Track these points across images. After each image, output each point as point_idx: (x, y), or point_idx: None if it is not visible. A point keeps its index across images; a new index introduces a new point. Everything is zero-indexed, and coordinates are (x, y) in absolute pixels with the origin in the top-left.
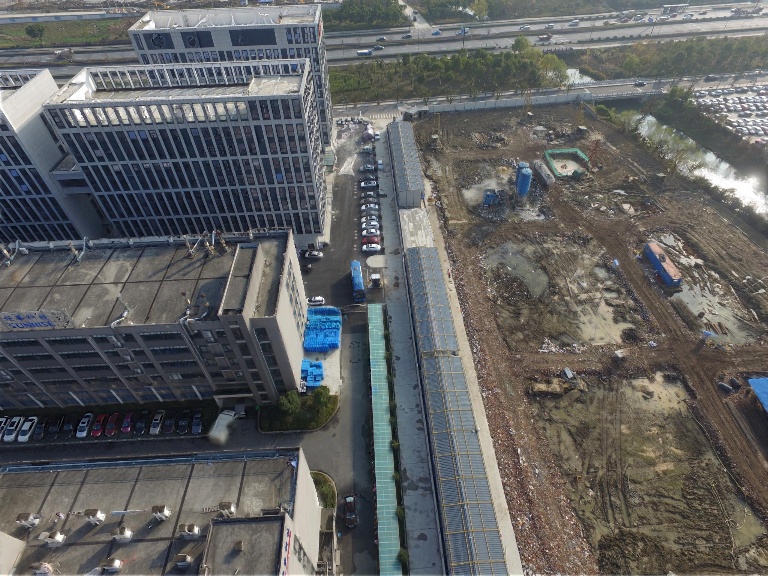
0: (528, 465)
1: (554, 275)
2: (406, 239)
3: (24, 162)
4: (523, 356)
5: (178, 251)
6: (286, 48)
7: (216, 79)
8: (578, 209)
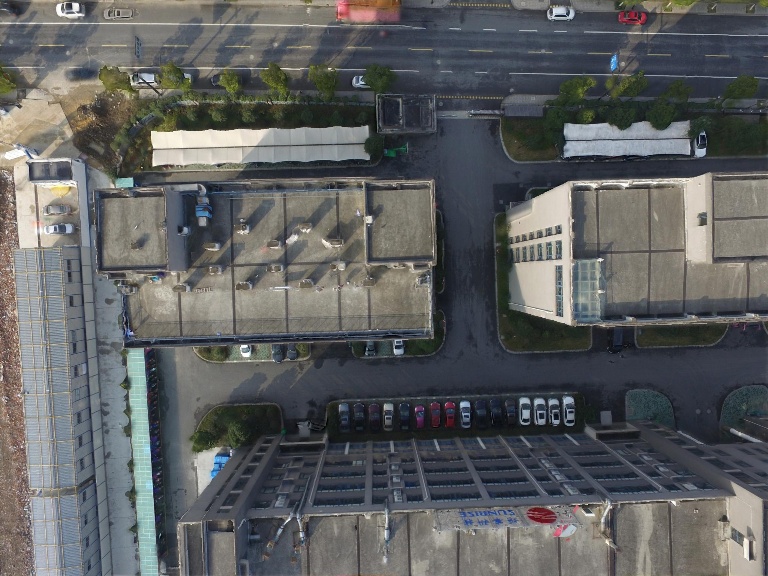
0: None
1: None
2: None
3: None
4: None
5: None
6: None
7: None
8: None
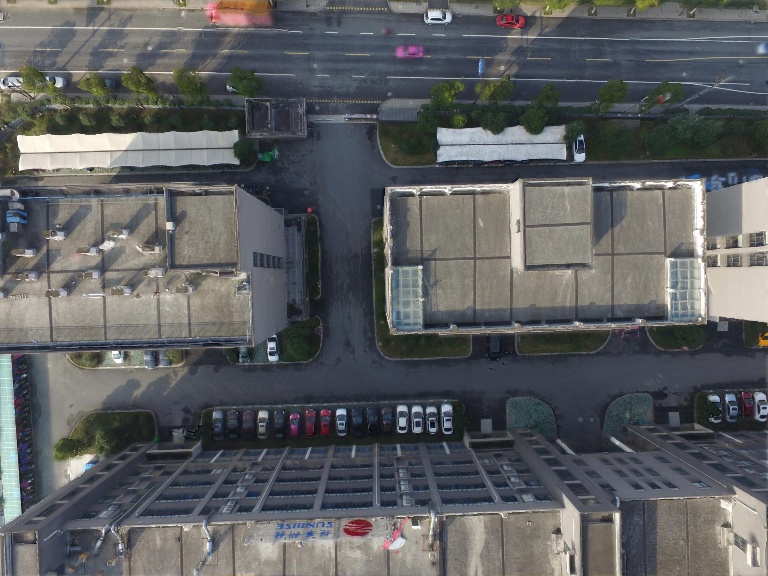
0: None
1: None
2: None
3: None
4: None
5: None
6: None
7: None
8: None
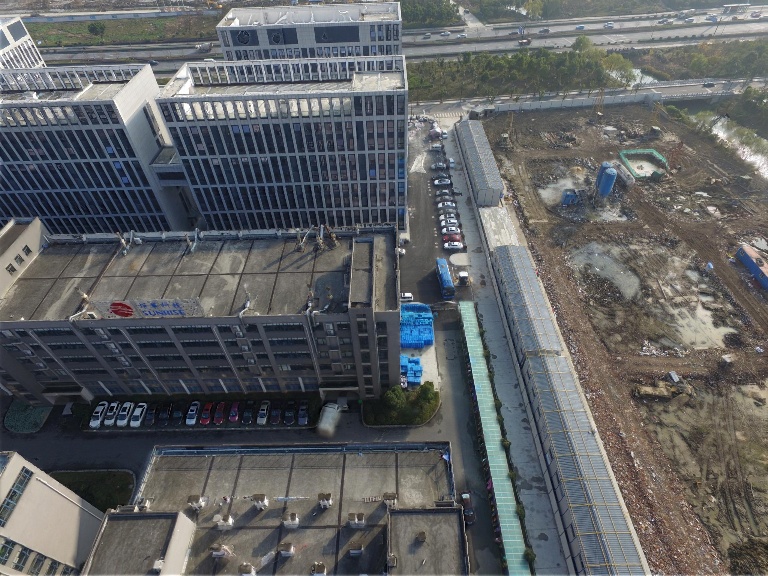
0: (644, 469)
1: (645, 277)
2: (490, 237)
3: (128, 155)
4: (624, 358)
5: (287, 244)
6: (368, 45)
7: (310, 75)
8: (661, 211)
